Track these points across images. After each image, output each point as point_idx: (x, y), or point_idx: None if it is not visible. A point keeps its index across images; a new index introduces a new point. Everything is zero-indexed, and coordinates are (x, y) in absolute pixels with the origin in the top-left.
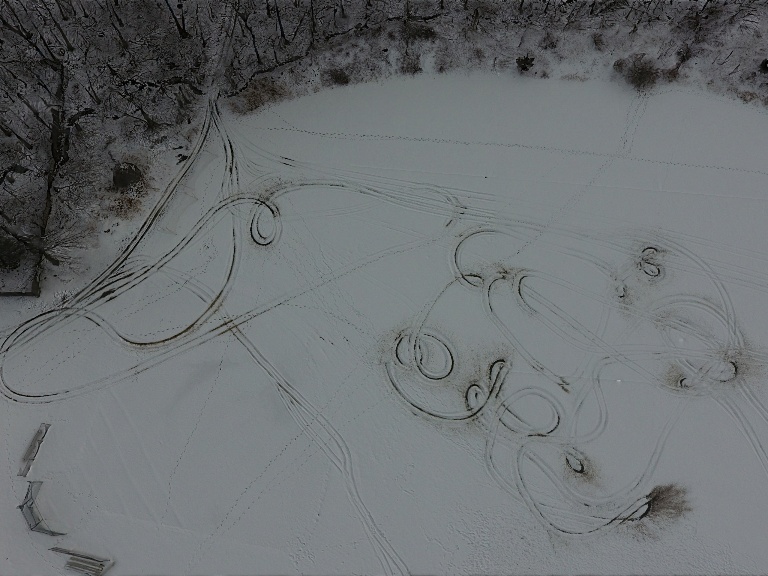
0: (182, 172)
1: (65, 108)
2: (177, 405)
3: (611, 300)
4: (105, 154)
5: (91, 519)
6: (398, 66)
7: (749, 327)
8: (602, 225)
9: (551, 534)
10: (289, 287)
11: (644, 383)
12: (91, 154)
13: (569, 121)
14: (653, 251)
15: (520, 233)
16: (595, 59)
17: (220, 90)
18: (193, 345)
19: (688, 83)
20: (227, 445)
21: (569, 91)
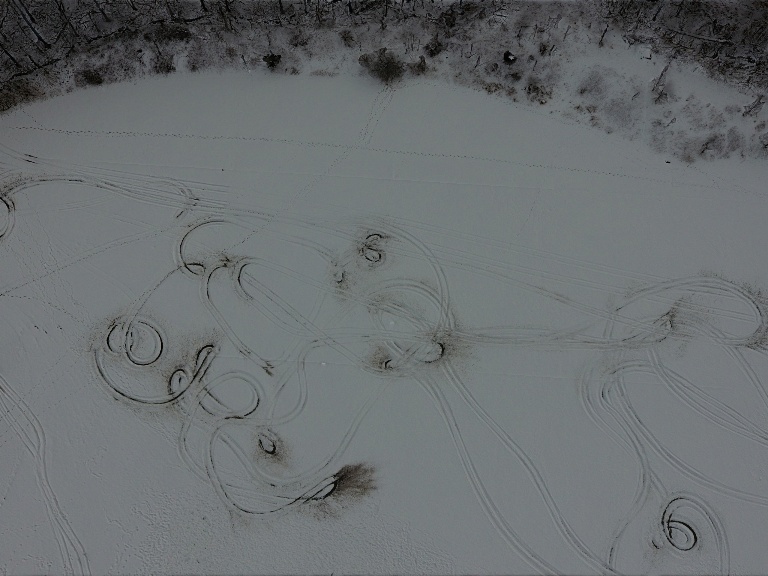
0: None
1: None
2: None
3: (328, 285)
4: None
5: None
6: (151, 66)
7: (462, 309)
8: (330, 213)
9: (233, 514)
10: (12, 278)
11: (348, 365)
12: None
13: (313, 115)
14: (377, 237)
15: (248, 222)
16: (345, 55)
17: None
18: None
19: (436, 76)
20: None
21: (317, 86)
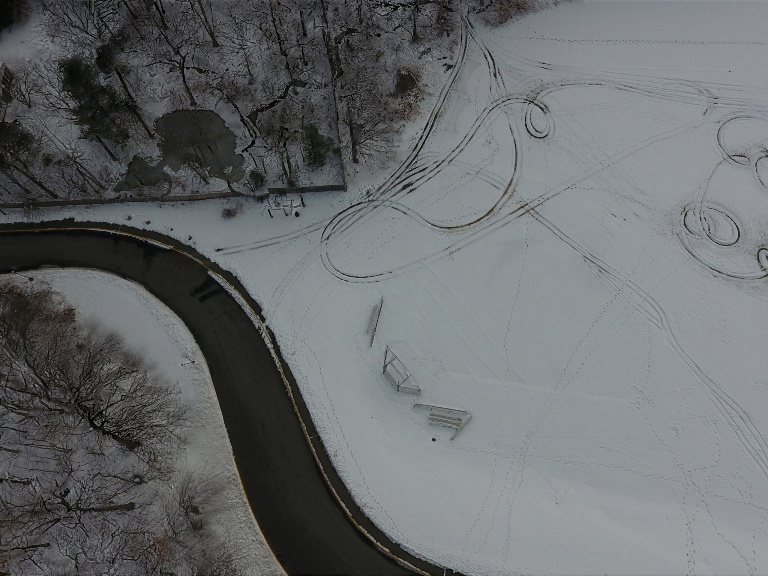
0: (451, 79)
1: (330, 29)
2: (495, 279)
3: None
4: (378, 66)
5: (440, 380)
6: None
7: None
8: None
9: None
10: (573, 173)
11: None
12: (365, 66)
13: None
14: None
15: None
16: None
17: (469, 7)
18: (497, 227)
19: None
20: (549, 311)
21: None
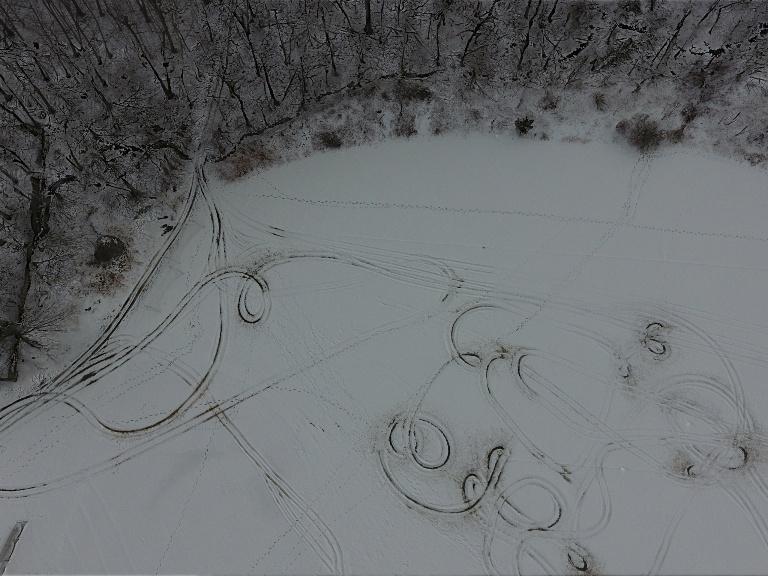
0: (167, 244)
1: (46, 175)
2: (160, 499)
3: (614, 381)
4: (87, 225)
5: None
6: (392, 128)
7: (759, 409)
8: (605, 299)
9: None
10: (278, 369)
11: (649, 471)
12: (72, 225)
13: (570, 186)
14: (658, 327)
15: (519, 308)
16: (597, 120)
17: (207, 155)
18: (177, 433)
19: (693, 144)
20: (212, 542)
21: (570, 154)
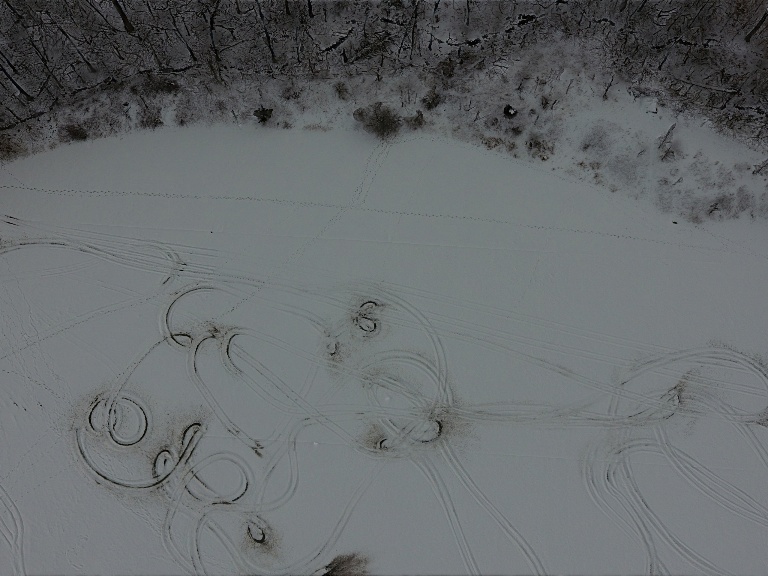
0: None
1: None
2: None
3: (321, 358)
4: None
5: None
6: (138, 120)
7: (460, 383)
8: (323, 279)
9: None
10: None
11: (342, 445)
12: None
13: (306, 172)
14: (372, 305)
15: (237, 289)
16: (339, 108)
17: None
18: None
19: (433, 130)
20: None
21: (310, 141)
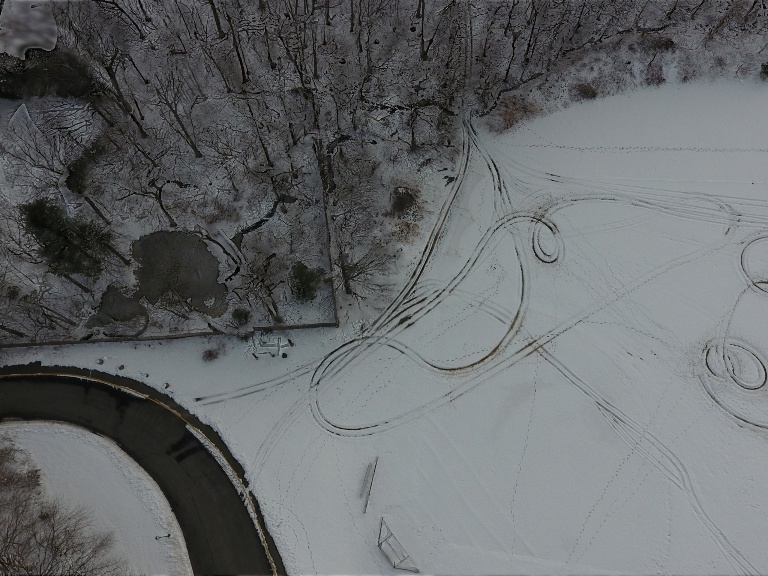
0: (452, 194)
1: (322, 136)
2: (500, 430)
3: None
4: (373, 179)
5: (440, 553)
6: (643, 78)
7: None
8: None
9: None
10: (585, 304)
11: None
12: (360, 180)
13: None
14: None
15: None
16: None
17: (471, 110)
18: (502, 368)
19: None
20: (560, 468)
21: None
